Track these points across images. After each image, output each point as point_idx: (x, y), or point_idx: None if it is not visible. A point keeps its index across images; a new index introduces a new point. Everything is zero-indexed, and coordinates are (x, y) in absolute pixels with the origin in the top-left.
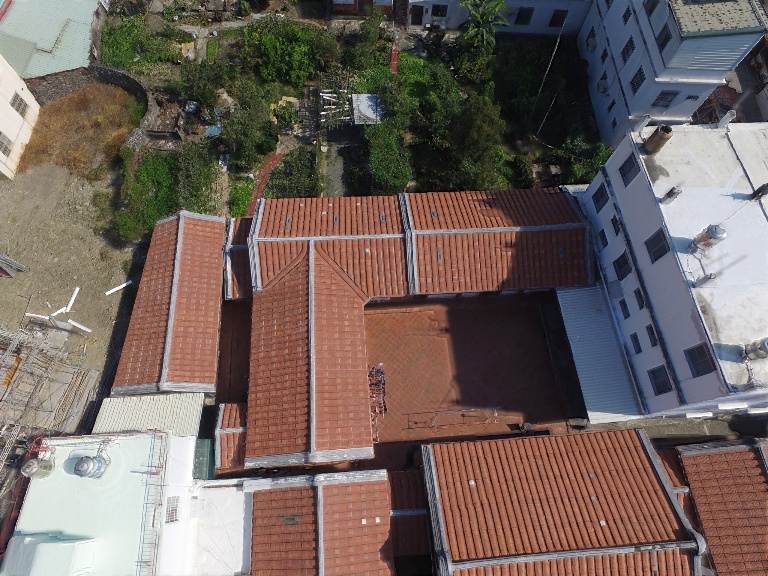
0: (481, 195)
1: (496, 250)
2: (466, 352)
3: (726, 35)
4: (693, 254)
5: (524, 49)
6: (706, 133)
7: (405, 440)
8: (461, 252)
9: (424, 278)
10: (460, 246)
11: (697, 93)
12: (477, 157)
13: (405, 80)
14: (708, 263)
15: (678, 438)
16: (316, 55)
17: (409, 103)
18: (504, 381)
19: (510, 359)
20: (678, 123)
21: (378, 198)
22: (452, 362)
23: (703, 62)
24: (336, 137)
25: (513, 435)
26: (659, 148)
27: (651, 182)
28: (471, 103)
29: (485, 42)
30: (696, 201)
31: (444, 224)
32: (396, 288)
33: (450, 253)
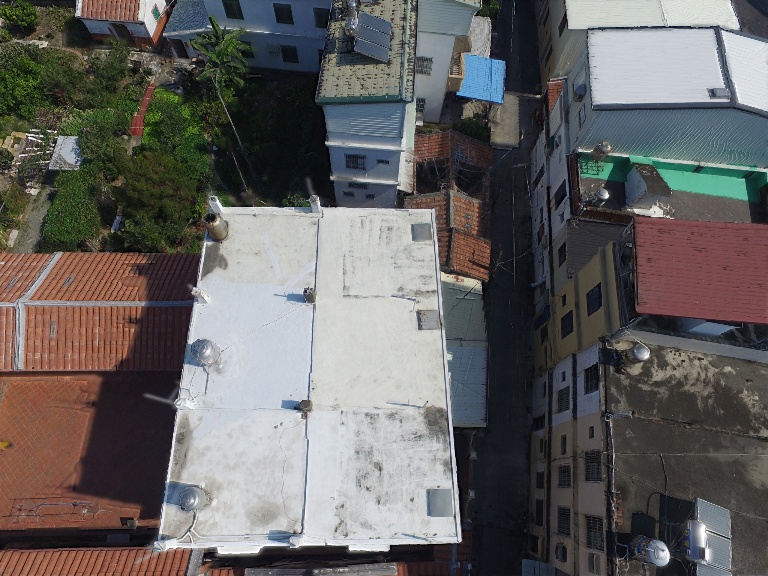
0: (142, 258)
1: (118, 326)
2: (106, 430)
3: (363, 103)
4: (204, 367)
5: (284, 90)
6: (295, 218)
7: (0, 529)
8: (78, 326)
9: (32, 353)
10: (78, 319)
11: (385, 158)
12: (155, 214)
13: (103, 125)
14: (216, 379)
15: (302, 547)
16: (44, 90)
17: (104, 150)
18: (135, 467)
19: (151, 441)
20: (387, 186)
21: (30, 256)
22: (86, 441)
23: (364, 128)
24: (53, 179)
25: (122, 531)
26: (218, 236)
27: (200, 275)
28: (117, 160)
29: (217, 84)
30: (241, 301)
31: (69, 293)
32: (3, 362)
33: (65, 327)
